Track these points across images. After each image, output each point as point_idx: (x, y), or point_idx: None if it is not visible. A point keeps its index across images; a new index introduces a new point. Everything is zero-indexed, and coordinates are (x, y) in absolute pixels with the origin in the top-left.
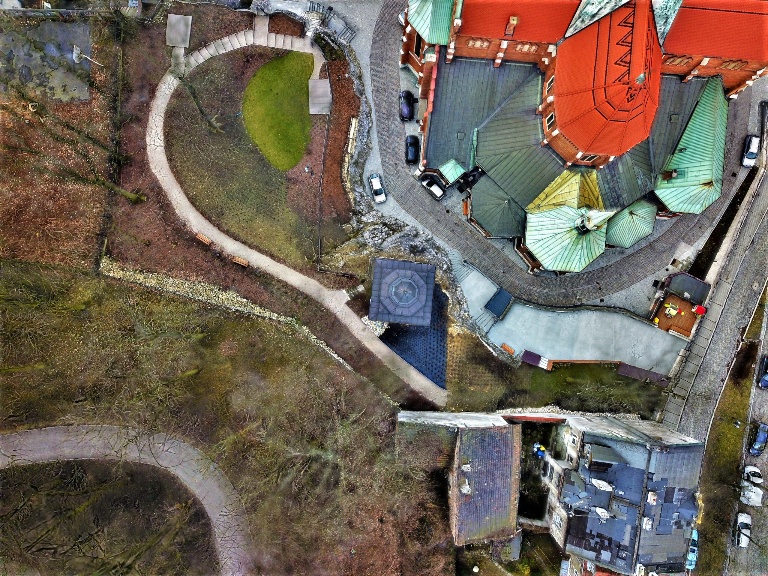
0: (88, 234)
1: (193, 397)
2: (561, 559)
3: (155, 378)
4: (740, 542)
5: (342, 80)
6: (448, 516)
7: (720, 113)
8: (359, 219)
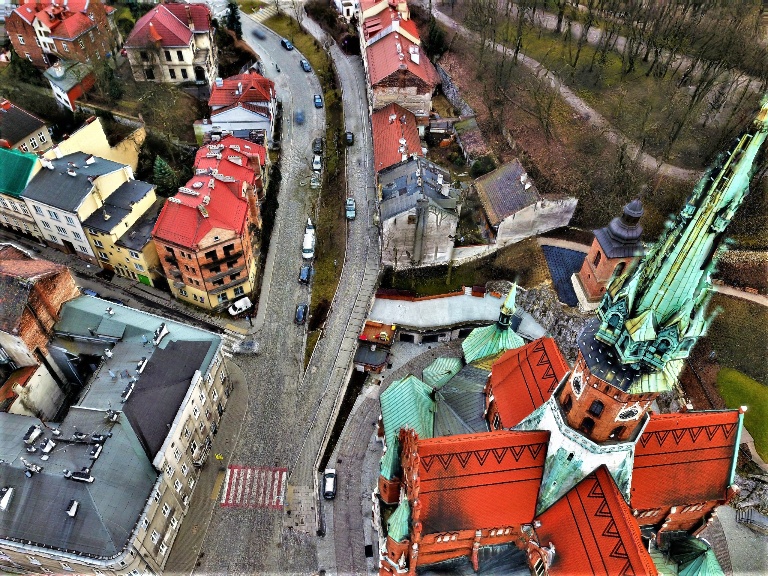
0: None
1: None
2: None
3: None
4: None
5: None
6: None
7: None
8: None
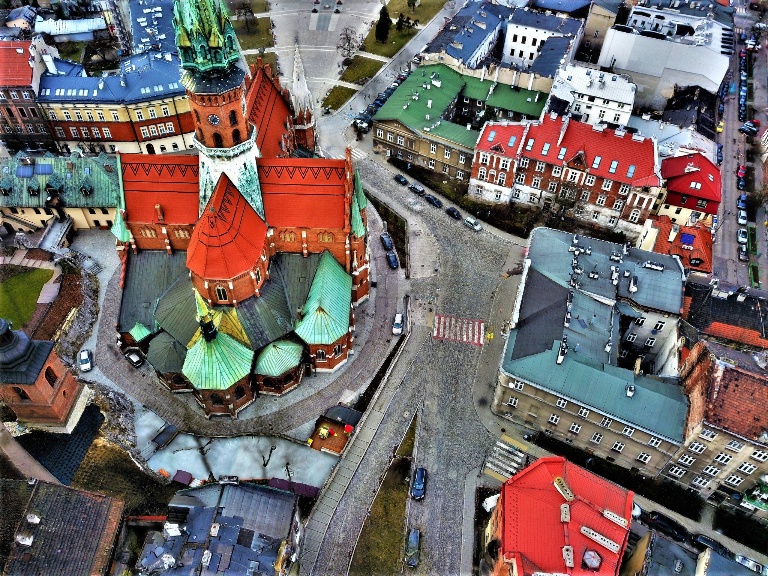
0: None
1: None
2: None
3: None
4: None
5: (73, 285)
6: None
7: (336, 276)
8: None
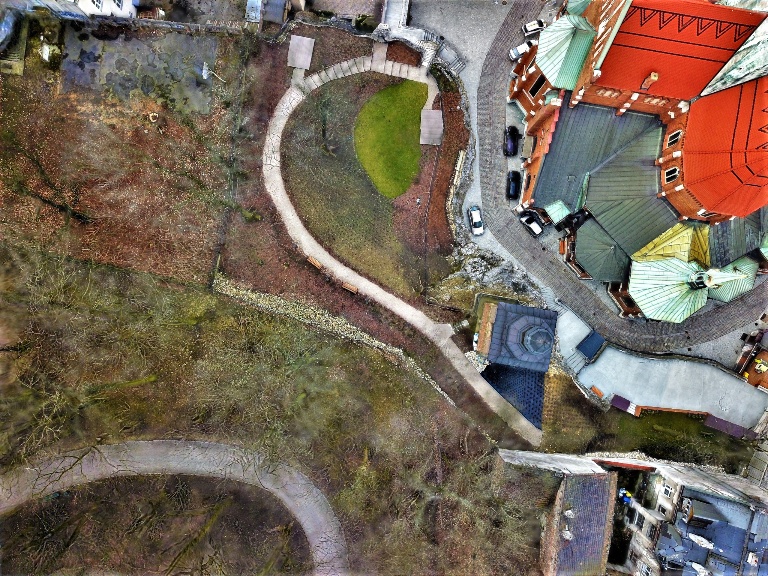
0: (201, 249)
1: (301, 421)
2: None
3: (264, 399)
4: None
5: (453, 112)
6: (538, 557)
7: None
8: (459, 251)
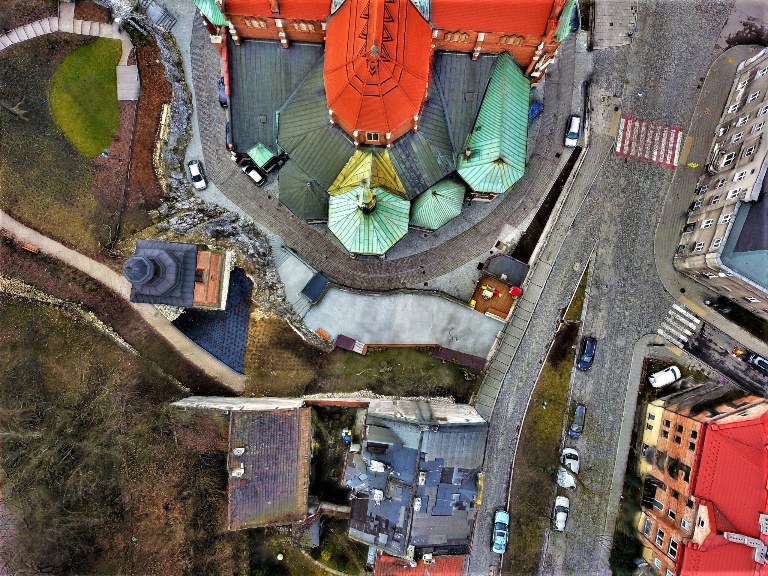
0: None
1: None
2: (368, 545)
3: None
4: (556, 525)
5: (153, 66)
6: None
7: (515, 90)
8: (172, 205)
